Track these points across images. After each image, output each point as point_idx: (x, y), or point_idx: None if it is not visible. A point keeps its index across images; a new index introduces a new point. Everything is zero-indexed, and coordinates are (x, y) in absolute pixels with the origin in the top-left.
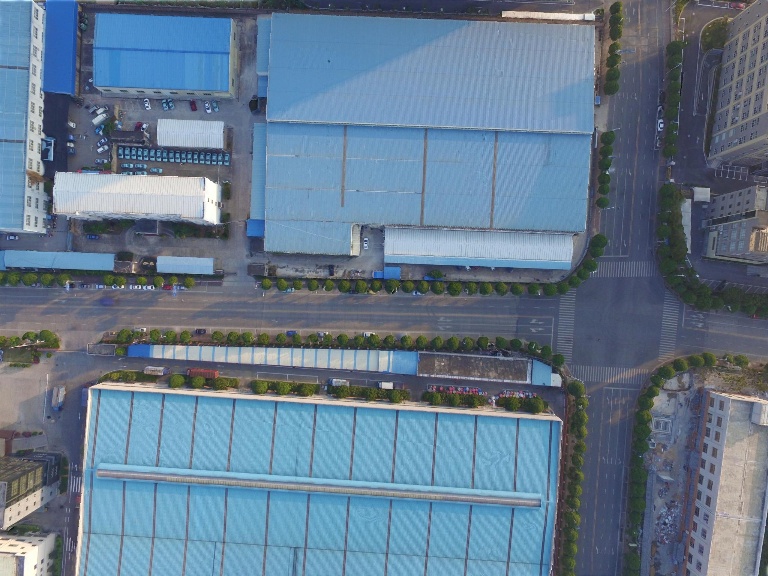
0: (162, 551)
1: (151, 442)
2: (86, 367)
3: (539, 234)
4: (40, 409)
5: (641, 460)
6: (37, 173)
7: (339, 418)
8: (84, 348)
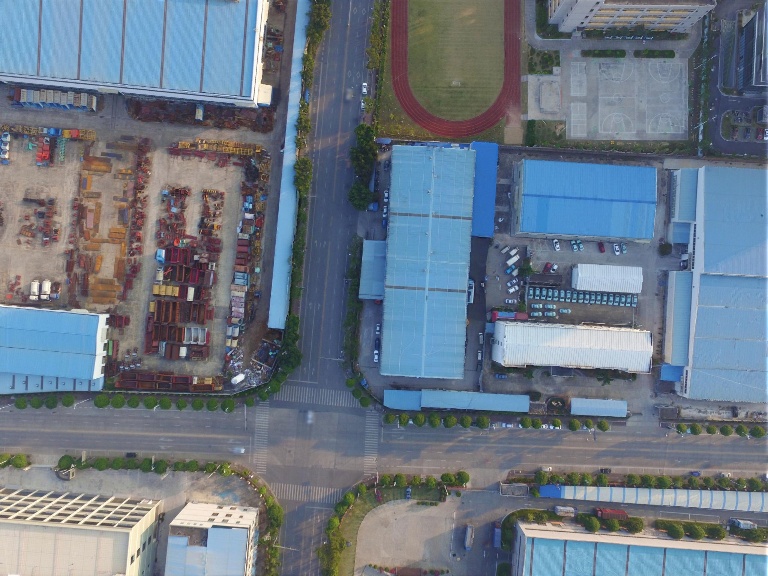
0: None
1: None
2: (492, 505)
3: None
4: (445, 547)
5: None
6: None
7: (767, 567)
8: (490, 486)
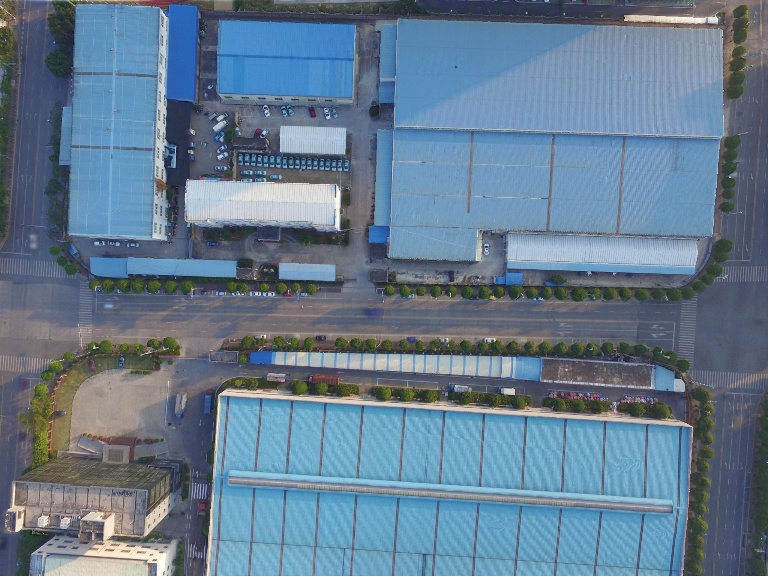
0: (291, 558)
1: (277, 449)
2: (206, 374)
3: (663, 239)
4: (161, 416)
5: (767, 466)
6: (162, 181)
7: (468, 425)
8: (204, 355)
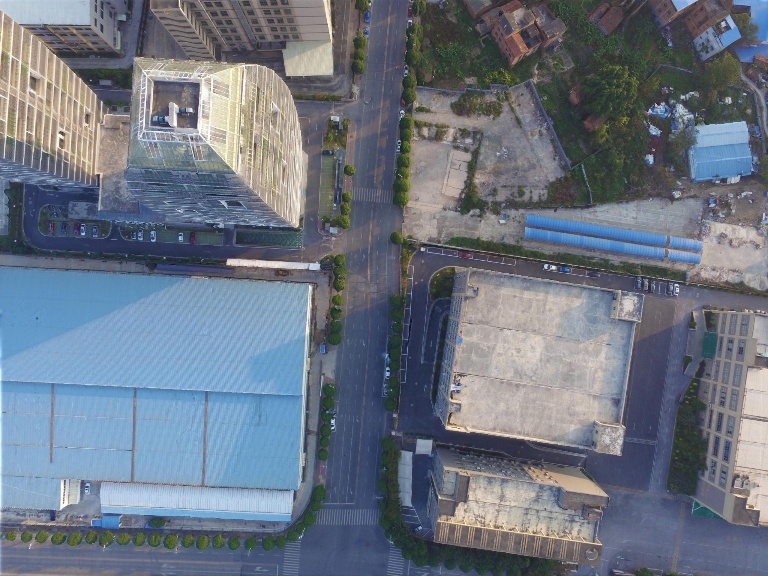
0: None
1: None
2: None
3: None
4: None
5: None
6: None
7: None
8: None
